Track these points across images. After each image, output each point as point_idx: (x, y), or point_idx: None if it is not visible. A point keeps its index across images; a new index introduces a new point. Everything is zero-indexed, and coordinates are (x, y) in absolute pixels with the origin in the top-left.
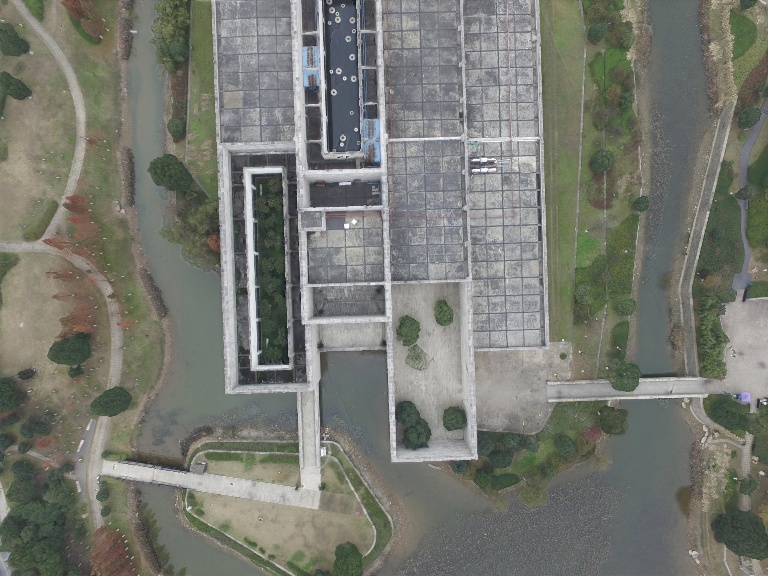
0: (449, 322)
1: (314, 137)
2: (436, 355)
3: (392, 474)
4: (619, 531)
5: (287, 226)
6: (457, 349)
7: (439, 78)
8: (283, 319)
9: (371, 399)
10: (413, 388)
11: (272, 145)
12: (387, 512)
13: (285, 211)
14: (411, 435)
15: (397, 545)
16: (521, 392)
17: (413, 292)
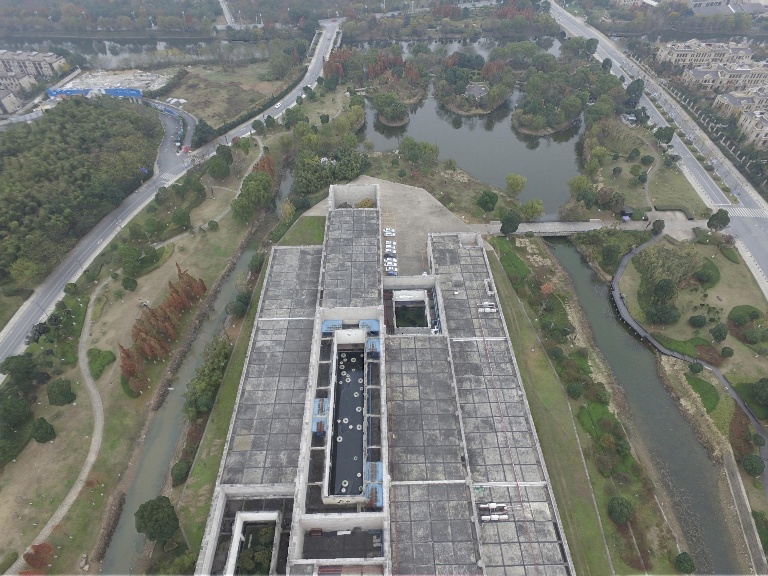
0: None
1: (316, 481)
2: None
3: None
4: None
5: None
6: None
7: (438, 425)
8: None
9: None
10: None
11: (272, 487)
12: None
13: (272, 566)
14: None
15: None
16: None
17: None
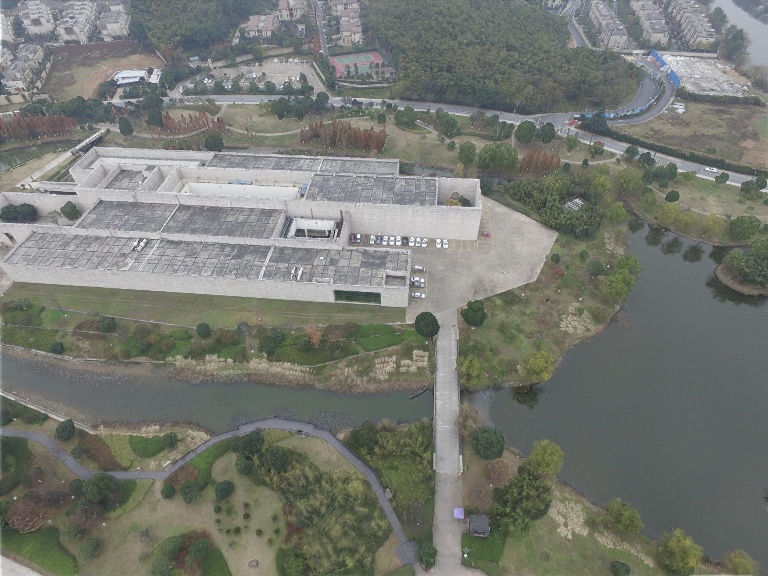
0: None
1: None
2: None
3: None
4: None
5: None
6: None
7: (203, 227)
8: None
9: None
10: None
11: None
12: None
13: None
14: None
15: None
16: None
17: None
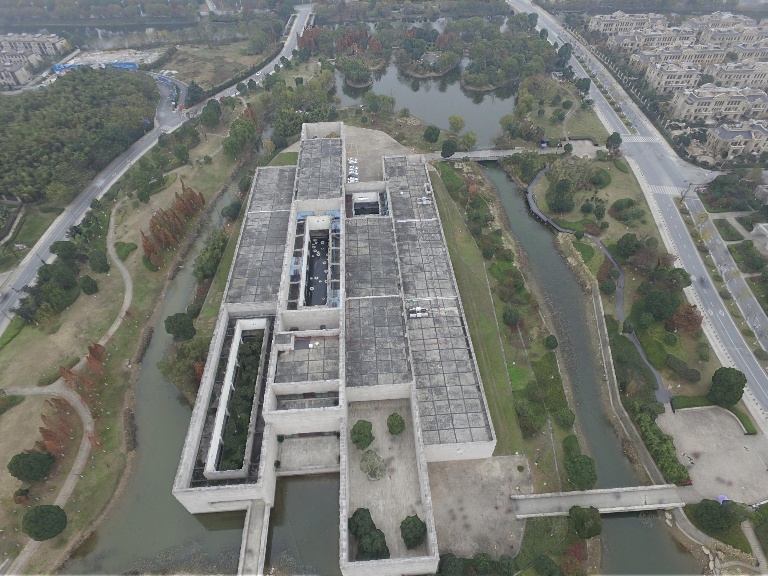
0: (401, 428)
1: (294, 306)
2: (393, 473)
3: None
4: None
5: (263, 357)
6: (414, 466)
7: (382, 267)
8: (245, 442)
9: (325, 530)
10: (370, 509)
11: (262, 305)
12: None
13: (263, 344)
14: (364, 540)
15: None
16: (486, 509)
17: (369, 415)
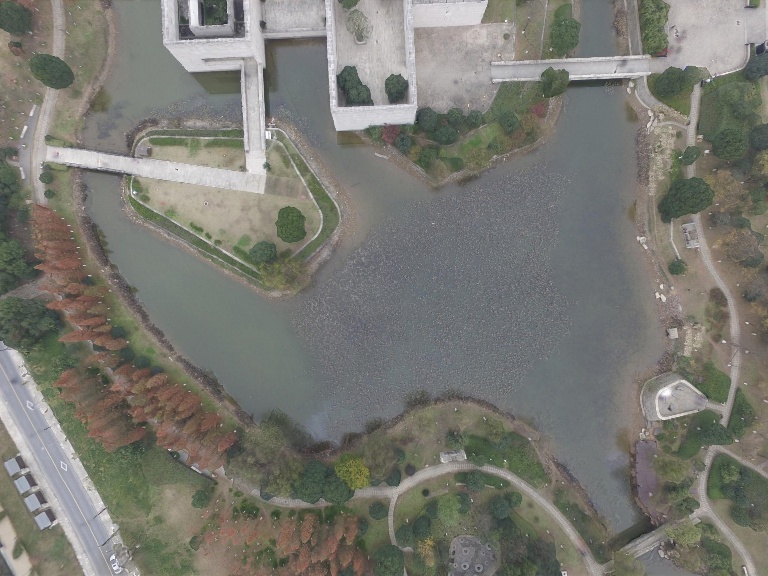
0: None
1: None
2: (380, 37)
3: (339, 165)
4: (567, 219)
5: None
6: (401, 31)
7: None
8: (226, 1)
9: (317, 89)
10: (357, 71)
11: None
12: (334, 200)
13: None
14: (351, 92)
15: (345, 235)
16: (465, 74)
17: None
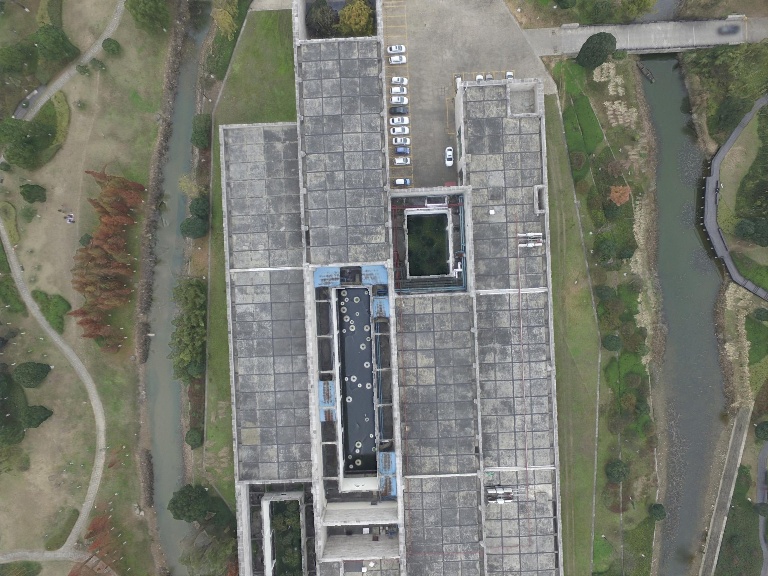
0: None
1: (330, 458)
2: None
3: None
4: None
5: (305, 553)
6: None
7: (454, 414)
8: None
9: None
10: None
11: None
12: None
13: (303, 543)
14: None
15: None
16: None
17: None
